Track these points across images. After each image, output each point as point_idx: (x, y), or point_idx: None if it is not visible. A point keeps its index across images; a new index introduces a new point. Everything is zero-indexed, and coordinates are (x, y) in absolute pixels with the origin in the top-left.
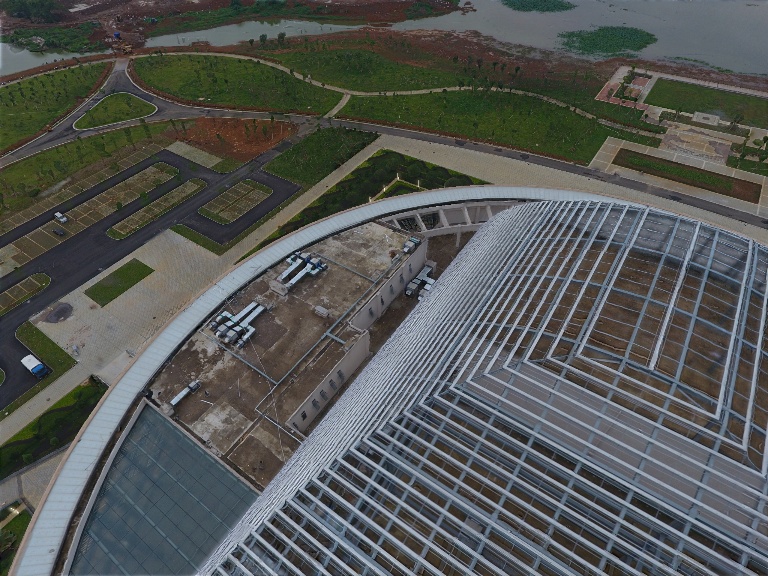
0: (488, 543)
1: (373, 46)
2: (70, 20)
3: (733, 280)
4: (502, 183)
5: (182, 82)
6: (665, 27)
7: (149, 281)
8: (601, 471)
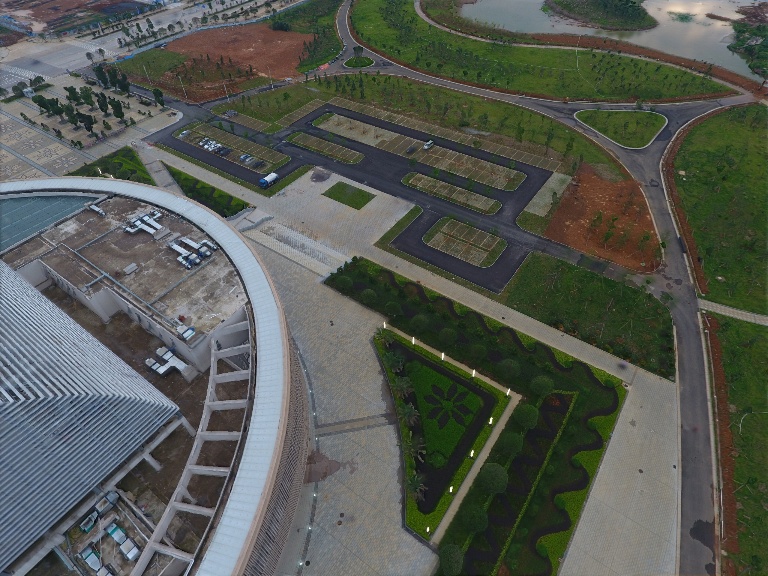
0: None
1: None
2: None
3: None
4: None
5: (715, 149)
6: None
7: (346, 210)
8: None
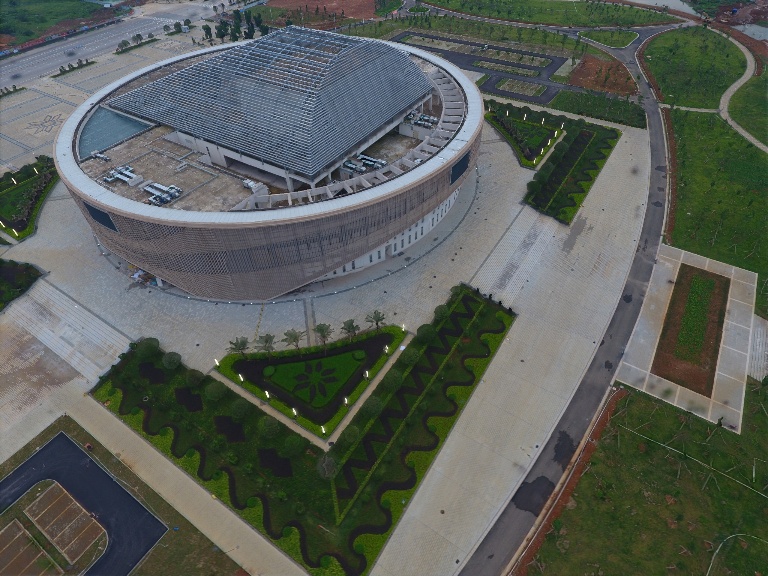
0: None
1: None
2: None
3: None
4: (597, 187)
5: (669, 45)
6: None
7: None
8: None
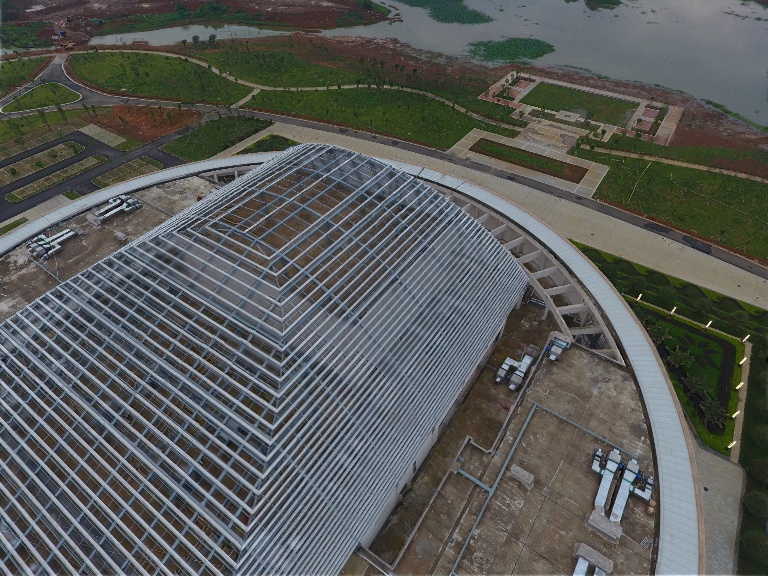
0: (108, 341)
1: (295, 49)
2: (23, 19)
3: (352, 187)
4: None
5: (110, 75)
6: (566, 40)
7: None
8: (190, 294)
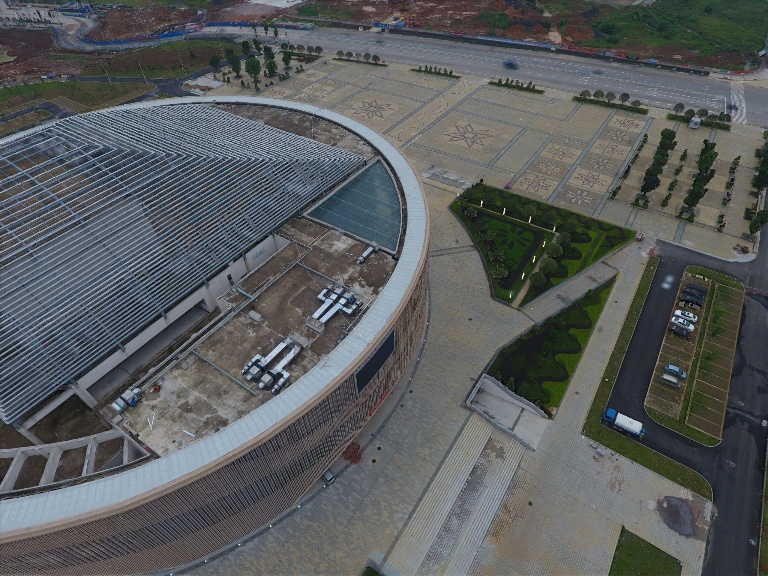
0: None
1: None
2: None
3: None
4: None
5: None
6: None
7: None
8: None
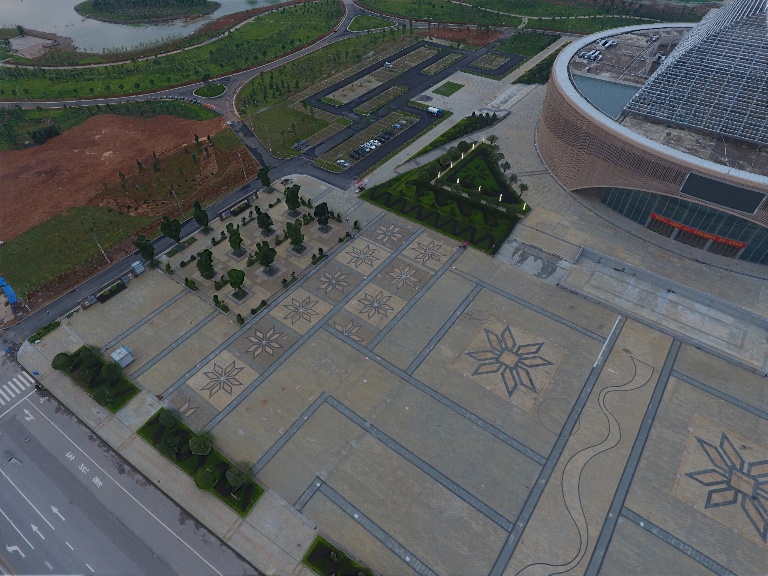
0: (762, 49)
1: None
2: None
3: None
4: None
5: (404, 9)
6: None
7: (466, 89)
8: None
